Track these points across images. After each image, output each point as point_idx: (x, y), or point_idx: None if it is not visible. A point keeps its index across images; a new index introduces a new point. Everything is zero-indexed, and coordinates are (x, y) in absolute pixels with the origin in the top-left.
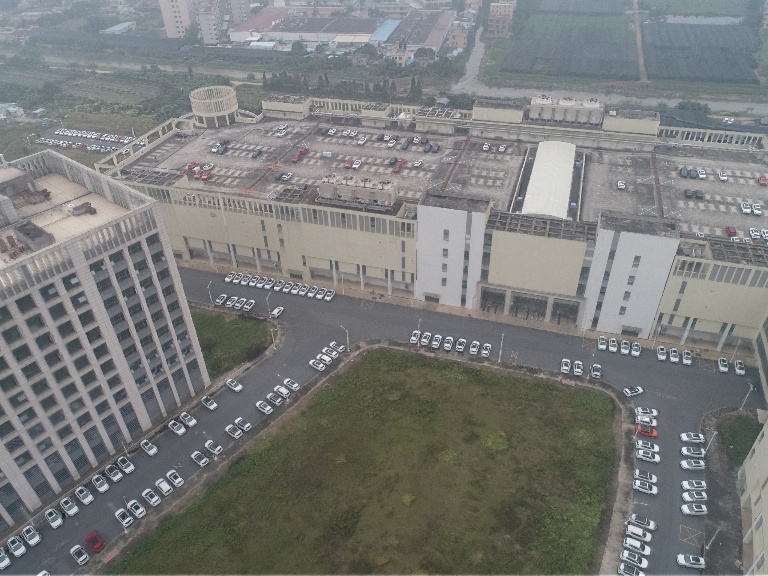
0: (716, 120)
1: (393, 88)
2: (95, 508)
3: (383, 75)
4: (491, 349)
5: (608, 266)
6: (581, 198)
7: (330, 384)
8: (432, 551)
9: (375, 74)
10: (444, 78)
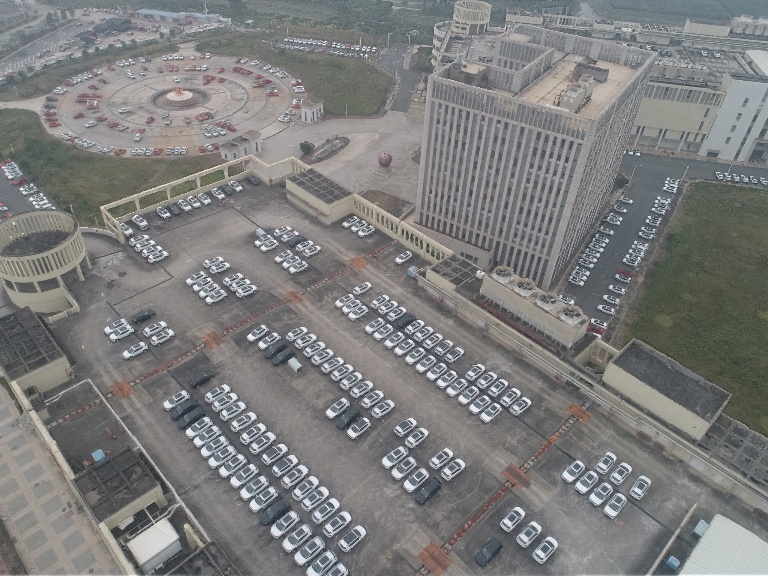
0: None
1: None
2: (604, 260)
3: (516, 7)
4: None
5: None
6: None
7: (688, 200)
8: None
9: (509, 6)
10: None
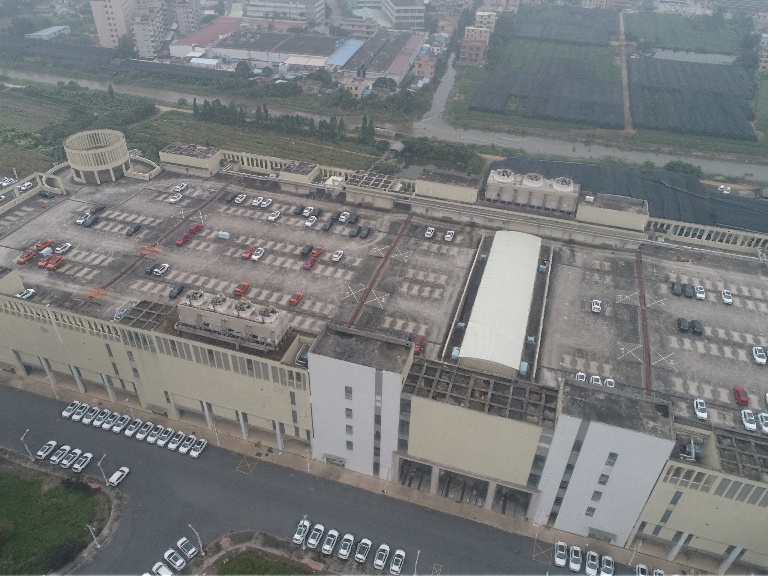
0: (710, 187)
1: (341, 127)
2: None
3: (335, 107)
4: (405, 558)
5: (571, 459)
6: (543, 325)
7: None
8: None
9: (326, 105)
10: (404, 114)
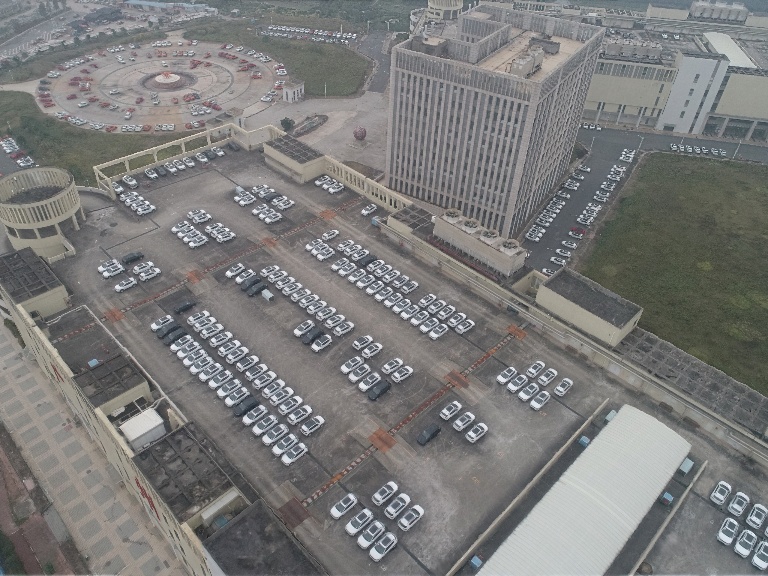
0: None
1: (520, 5)
2: (560, 220)
3: None
4: None
5: None
6: None
7: (642, 168)
8: (764, 229)
9: None
10: (546, 1)
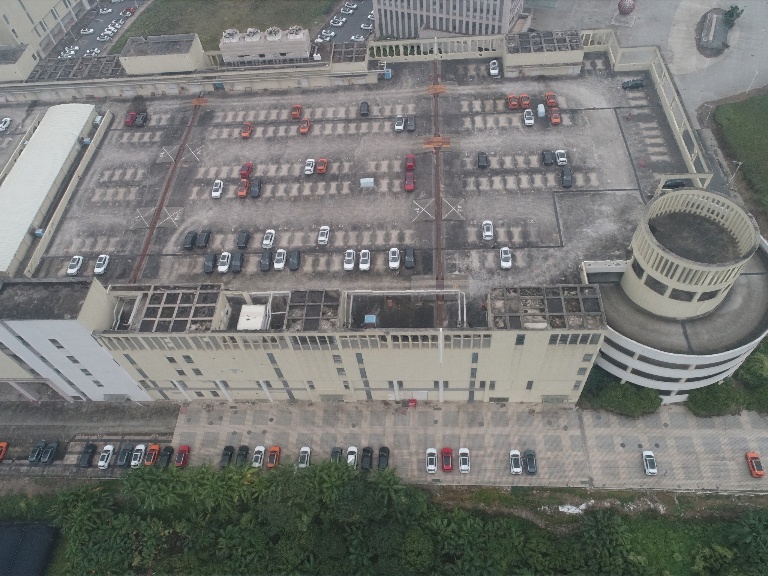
0: None
1: None
2: None
3: None
4: None
5: None
6: None
7: None
8: (212, 7)
9: None
10: None
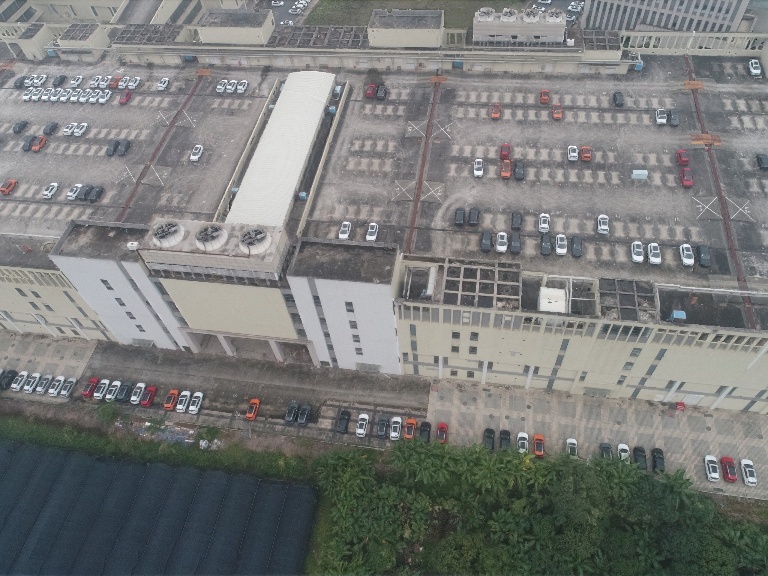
0: None
1: None
2: None
3: None
4: None
5: None
6: None
7: None
8: None
9: None
10: None
